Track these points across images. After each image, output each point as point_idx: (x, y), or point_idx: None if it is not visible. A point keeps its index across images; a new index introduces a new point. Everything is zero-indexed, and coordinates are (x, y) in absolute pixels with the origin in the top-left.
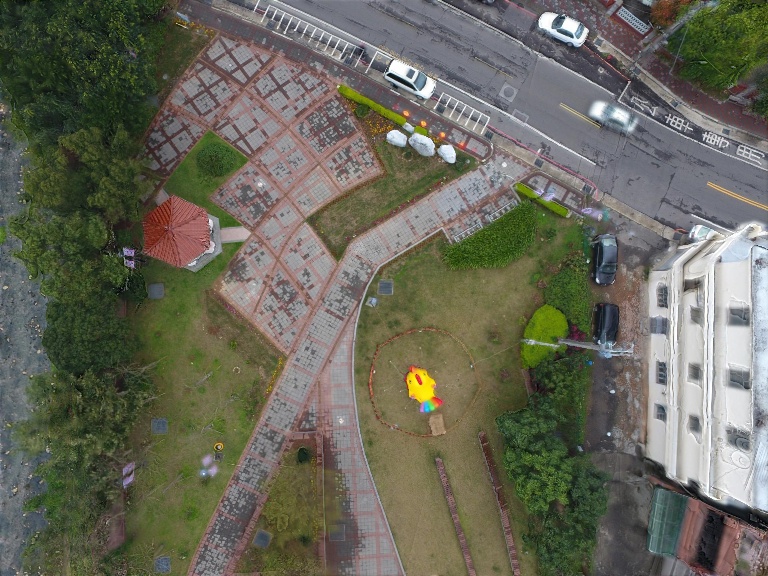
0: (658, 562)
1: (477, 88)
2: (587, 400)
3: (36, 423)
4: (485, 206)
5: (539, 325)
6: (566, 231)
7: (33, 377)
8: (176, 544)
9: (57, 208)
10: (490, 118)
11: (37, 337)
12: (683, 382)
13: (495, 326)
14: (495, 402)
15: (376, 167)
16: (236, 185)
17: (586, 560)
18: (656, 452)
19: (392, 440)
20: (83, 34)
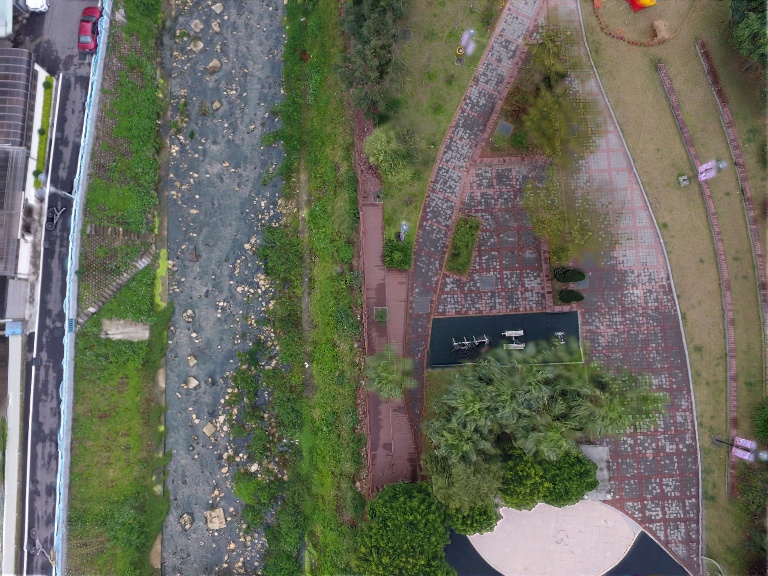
0: None
1: None
2: None
3: (270, 70)
4: None
5: None
6: None
7: (266, 30)
8: (425, 135)
9: None
10: None
11: None
12: None
13: None
14: (709, 16)
15: None
16: None
17: None
18: None
19: (616, 50)
20: None
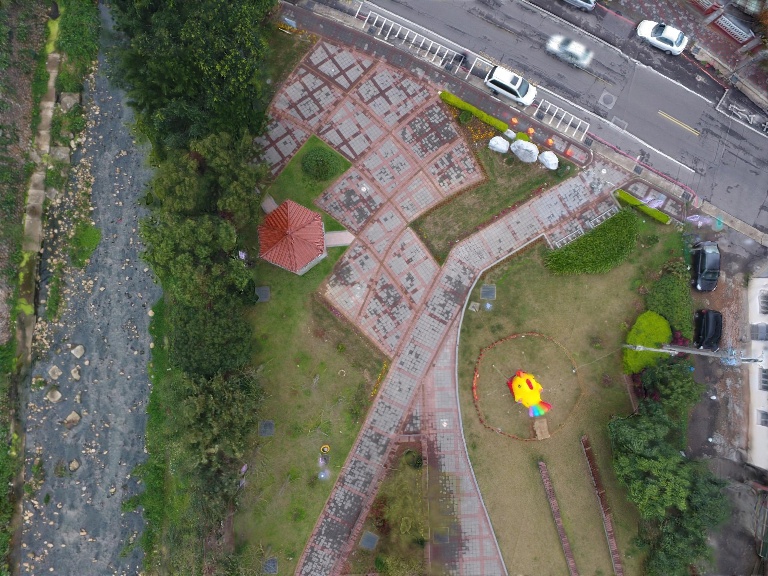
0: (759, 567)
1: (576, 95)
2: (688, 406)
3: (133, 423)
4: (585, 212)
5: (643, 331)
6: (666, 238)
7: (130, 378)
8: (283, 545)
9: (188, 212)
10: (590, 125)
11: (134, 338)
12: None
13: (597, 331)
14: (597, 407)
15: (478, 173)
16: (340, 189)
17: (691, 565)
18: (761, 458)
19: (495, 444)
20: (214, 40)
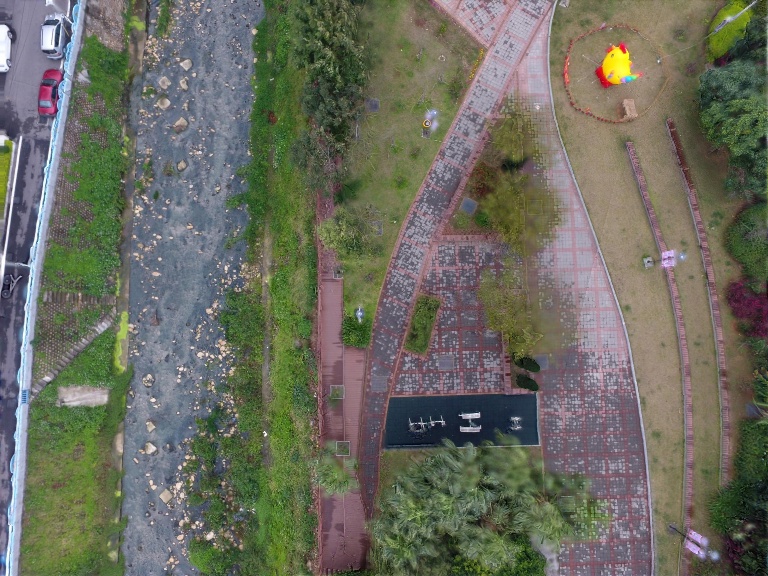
0: None
1: None
2: (766, 94)
3: (237, 130)
4: None
5: None
6: None
7: (235, 89)
8: (388, 209)
9: None
10: None
11: (238, 54)
12: None
13: (680, 26)
14: (681, 94)
15: None
16: None
17: None
18: None
19: (585, 125)
20: None
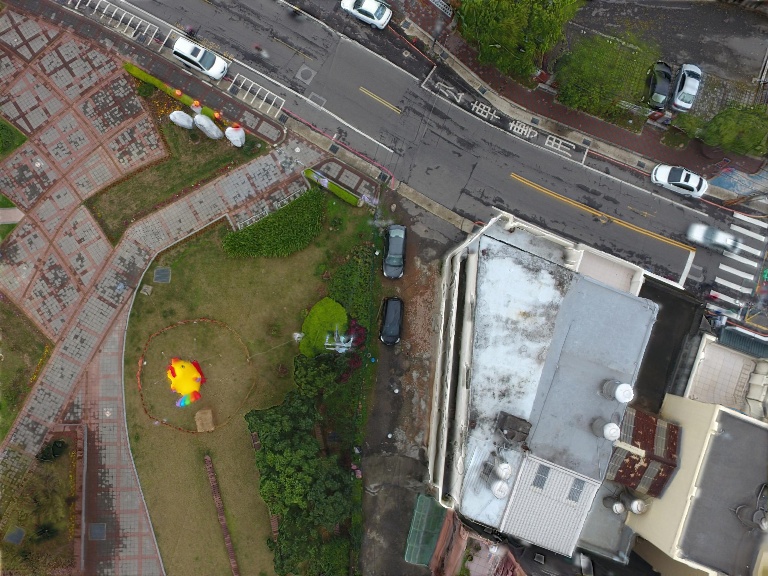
0: None
1: (274, 69)
2: (369, 399)
3: None
4: (274, 193)
5: (317, 318)
6: (357, 221)
7: None
8: None
9: None
10: (285, 101)
11: None
12: (444, 382)
13: (275, 318)
14: (271, 398)
15: (161, 149)
16: (12, 164)
17: (353, 569)
18: None
19: (160, 435)
20: None
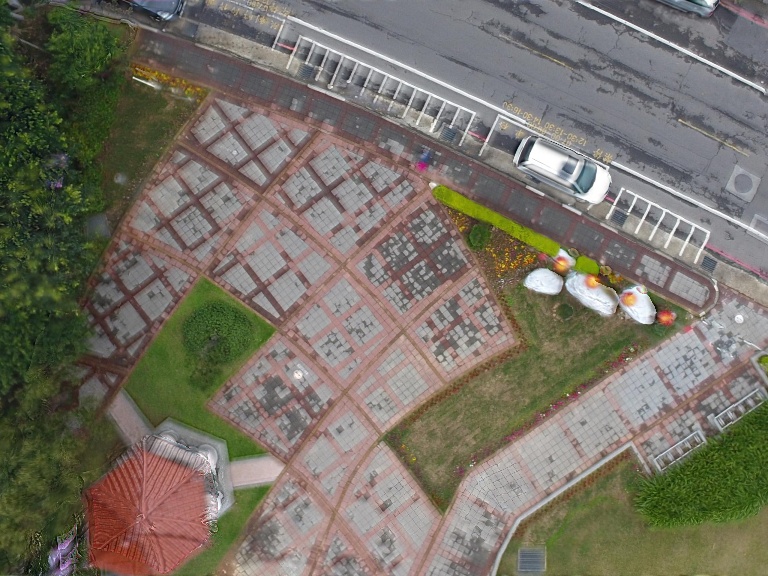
0: None
1: (684, 178)
2: None
3: None
4: (707, 398)
5: None
6: None
7: None
8: None
9: None
10: (711, 234)
11: None
12: None
13: None
14: None
15: (507, 333)
16: (255, 376)
17: None
18: None
19: None
20: None
